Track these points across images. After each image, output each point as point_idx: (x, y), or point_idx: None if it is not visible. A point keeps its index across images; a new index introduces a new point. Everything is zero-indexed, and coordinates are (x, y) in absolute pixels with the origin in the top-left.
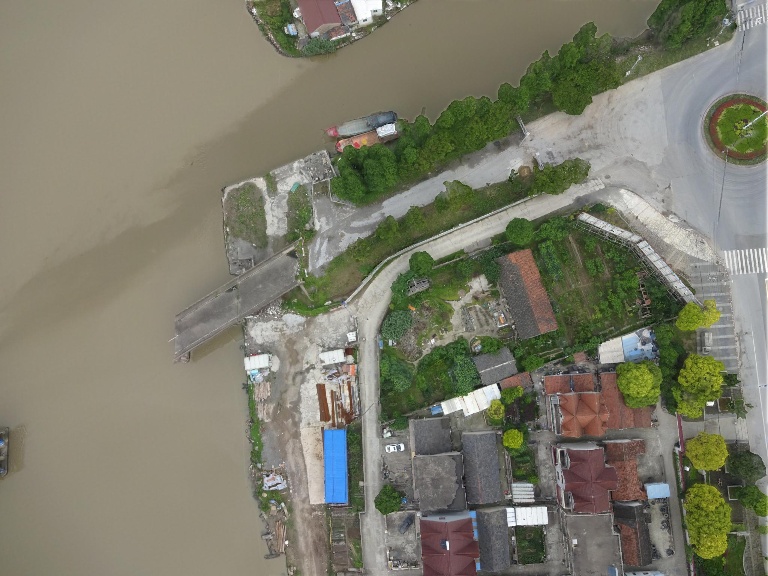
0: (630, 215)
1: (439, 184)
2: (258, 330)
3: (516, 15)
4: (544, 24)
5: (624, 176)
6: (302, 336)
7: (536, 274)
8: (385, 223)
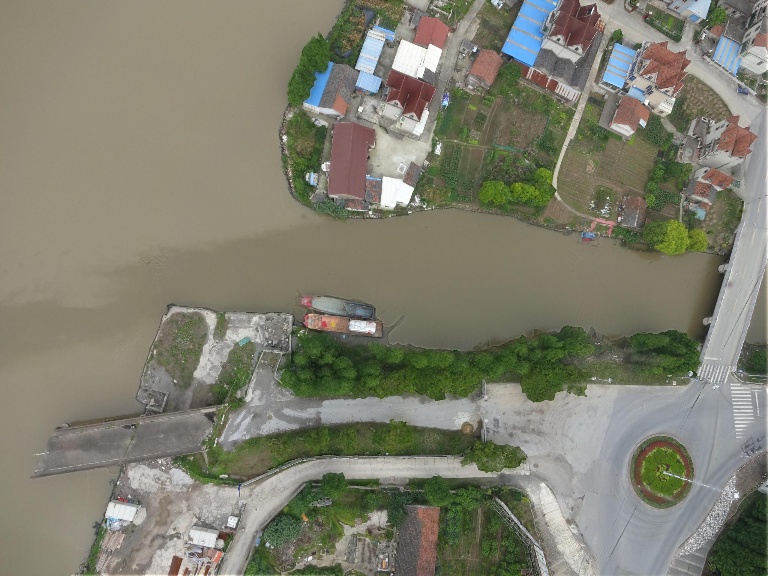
0: (539, 510)
1: (385, 406)
2: (138, 473)
3: (523, 262)
4: (543, 280)
5: (550, 471)
6: (182, 498)
7: (435, 535)
8: (317, 433)
